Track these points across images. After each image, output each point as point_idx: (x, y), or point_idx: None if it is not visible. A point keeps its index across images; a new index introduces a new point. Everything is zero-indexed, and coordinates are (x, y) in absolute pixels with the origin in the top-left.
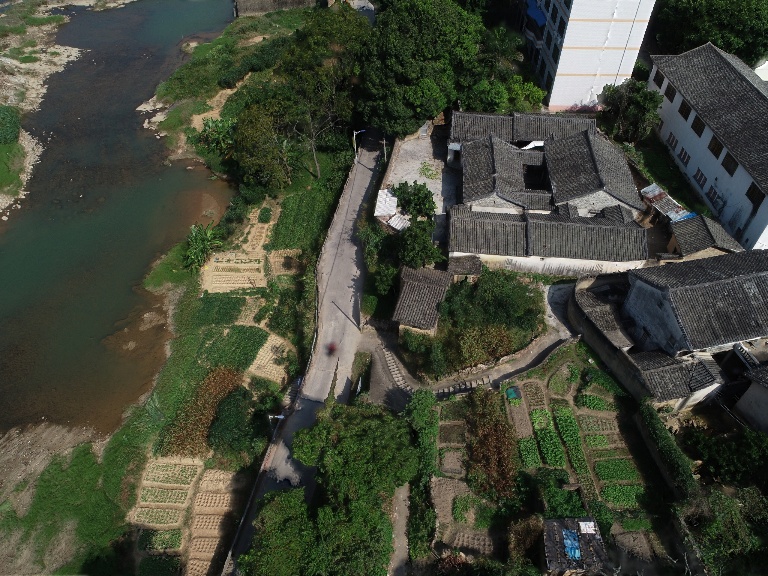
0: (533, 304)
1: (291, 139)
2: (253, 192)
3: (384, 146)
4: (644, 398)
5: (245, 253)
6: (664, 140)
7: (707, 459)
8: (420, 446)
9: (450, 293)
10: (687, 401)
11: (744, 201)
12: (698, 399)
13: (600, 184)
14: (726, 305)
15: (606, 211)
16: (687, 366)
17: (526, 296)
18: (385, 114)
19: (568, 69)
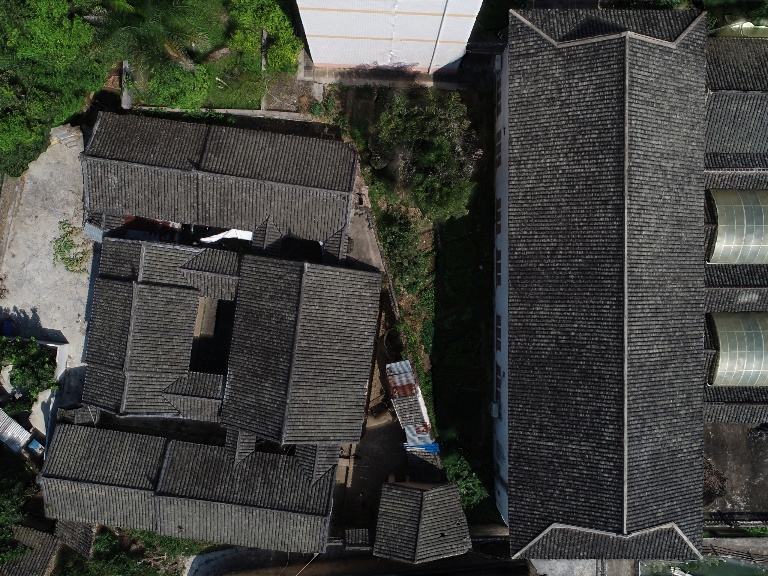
0: None
1: None
2: None
3: None
4: None
5: None
6: (495, 193)
7: None
8: None
9: None
10: None
11: (507, 460)
12: None
13: (280, 430)
14: None
15: None
16: None
17: None
18: None
19: (328, 31)
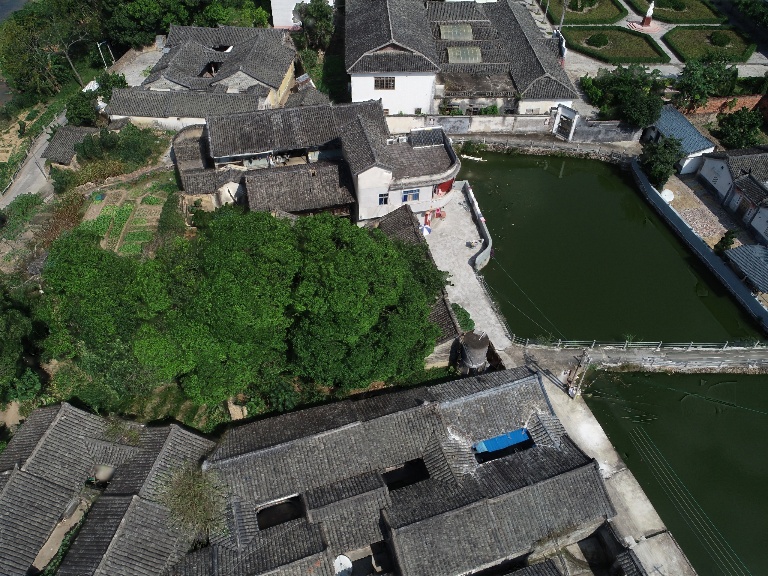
0: (153, 147)
1: (76, 60)
2: (22, 96)
3: (110, 51)
4: (173, 190)
5: (2, 140)
6: None
7: (199, 226)
8: (10, 225)
9: (89, 138)
10: (221, 199)
11: None
12: (231, 198)
13: None
14: (251, 129)
15: (248, 89)
16: (219, 173)
17: (153, 143)
18: (116, 27)
19: None
